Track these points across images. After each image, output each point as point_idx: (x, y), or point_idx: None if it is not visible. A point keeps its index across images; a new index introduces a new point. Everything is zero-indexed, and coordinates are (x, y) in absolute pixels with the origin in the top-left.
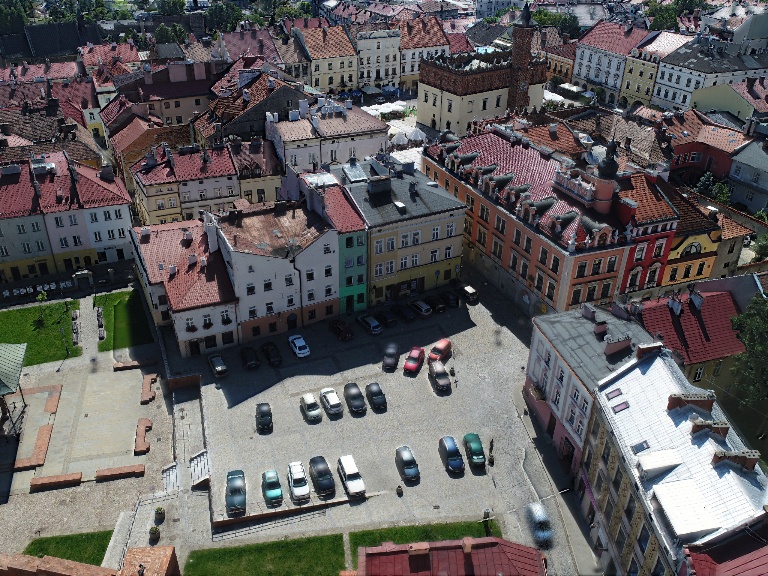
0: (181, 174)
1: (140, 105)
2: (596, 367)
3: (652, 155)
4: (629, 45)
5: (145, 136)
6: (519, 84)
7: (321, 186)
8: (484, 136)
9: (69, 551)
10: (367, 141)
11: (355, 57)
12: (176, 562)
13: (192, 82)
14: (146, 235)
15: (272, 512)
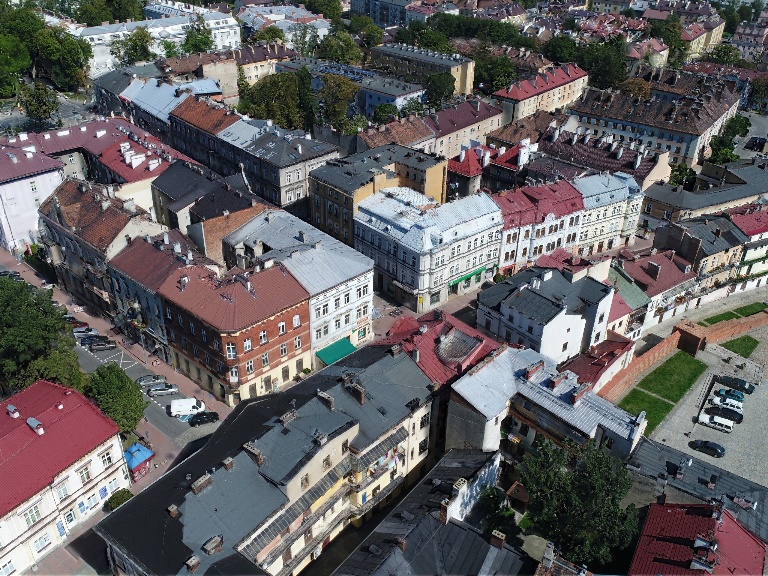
0: None
1: None
2: (674, 457)
3: None
4: None
5: None
6: None
7: None
8: None
9: None
10: None
11: None
12: None
13: None
14: None
15: (712, 390)
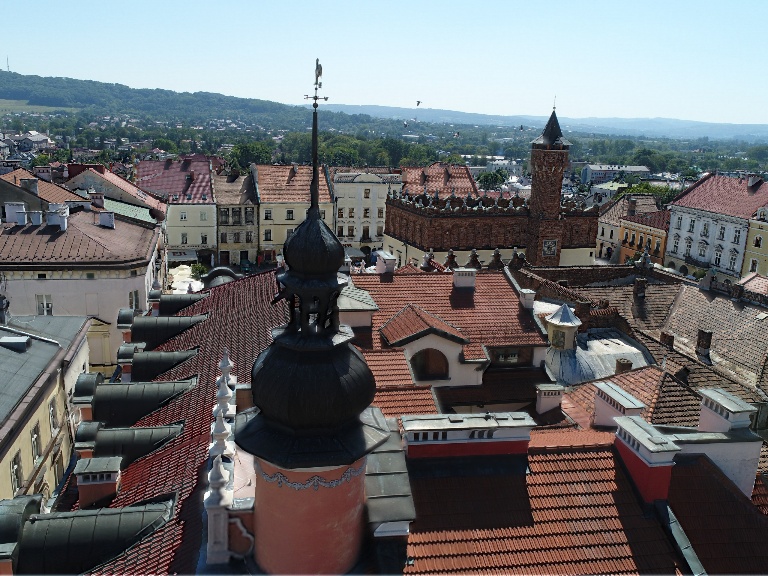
0: None
1: None
2: None
3: (765, 378)
4: (754, 204)
5: None
6: (540, 242)
7: None
8: (255, 278)
9: None
10: (79, 284)
11: (330, 206)
12: None
13: None
14: None
15: None
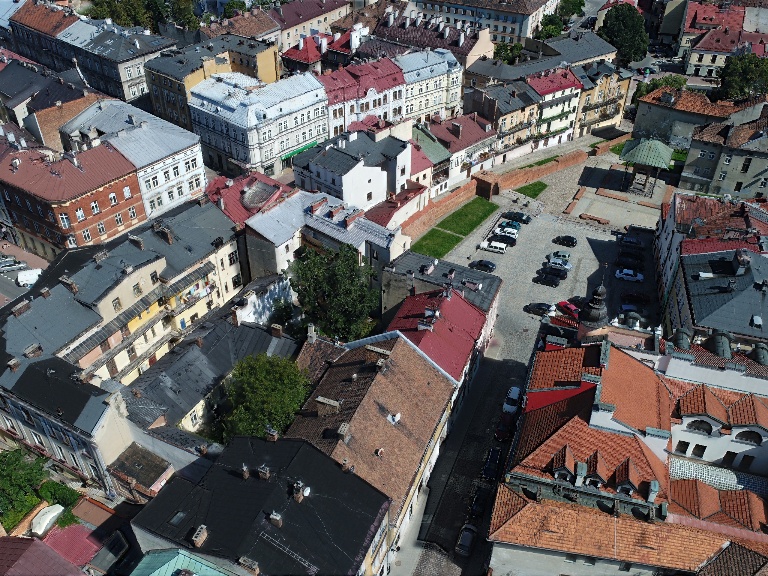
0: None
1: None
2: None
3: None
4: None
5: None
6: None
7: (761, 241)
8: None
9: (533, 189)
10: None
11: None
12: (490, 191)
13: None
14: None
15: None
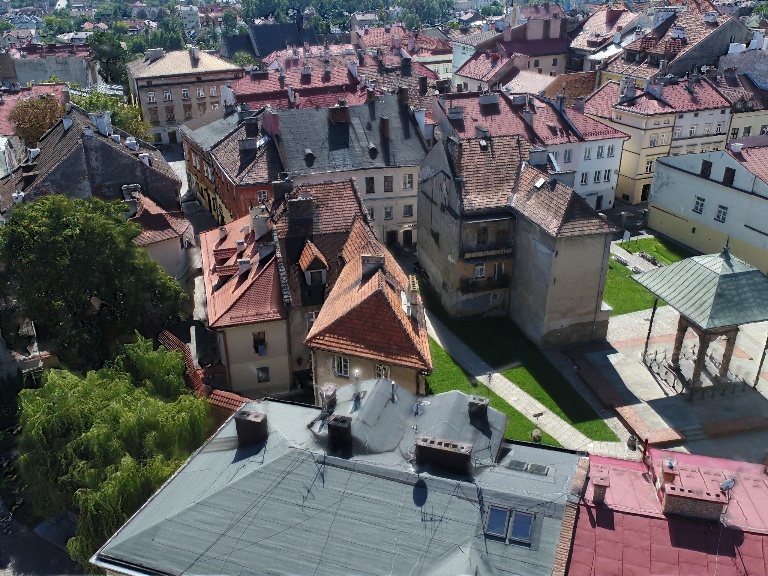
0: (675, 105)
1: (522, 57)
2: None
3: None
4: None
5: (555, 83)
6: None
7: None
8: None
9: None
10: None
11: None
12: None
13: (547, 40)
14: (737, 153)
15: None
